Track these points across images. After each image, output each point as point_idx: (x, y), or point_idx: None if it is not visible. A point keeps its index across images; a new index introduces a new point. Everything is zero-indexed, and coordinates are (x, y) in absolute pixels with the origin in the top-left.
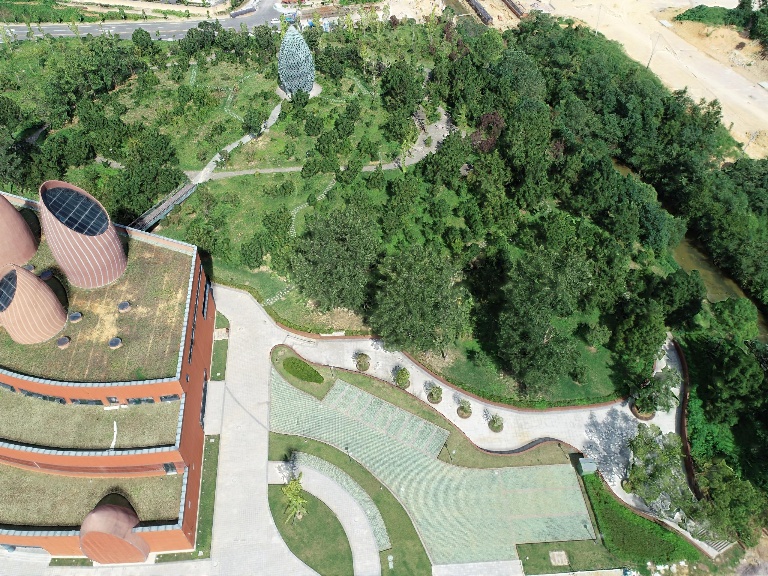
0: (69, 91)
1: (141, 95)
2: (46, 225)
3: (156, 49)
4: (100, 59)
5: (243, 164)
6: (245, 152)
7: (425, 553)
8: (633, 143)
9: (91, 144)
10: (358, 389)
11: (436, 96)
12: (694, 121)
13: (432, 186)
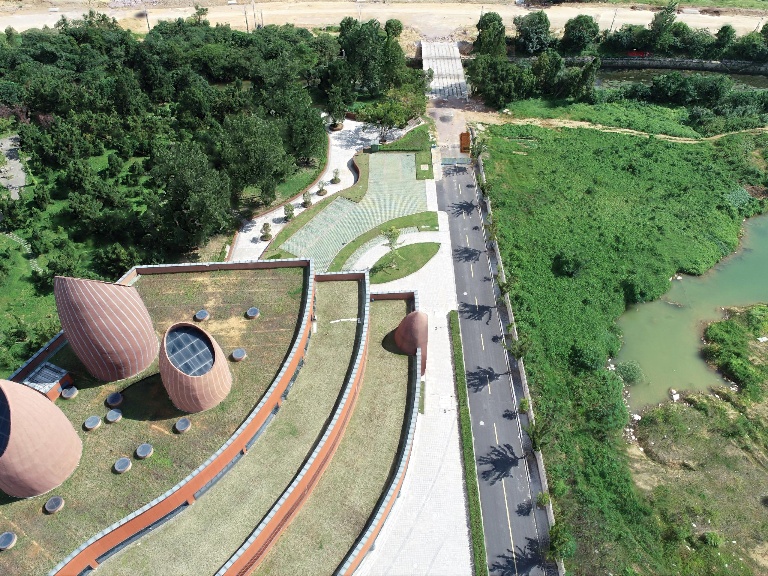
0: None
1: None
2: (113, 305)
3: None
4: None
5: None
6: None
7: (421, 213)
8: (88, 69)
9: None
10: (292, 237)
11: None
12: (100, 30)
13: None
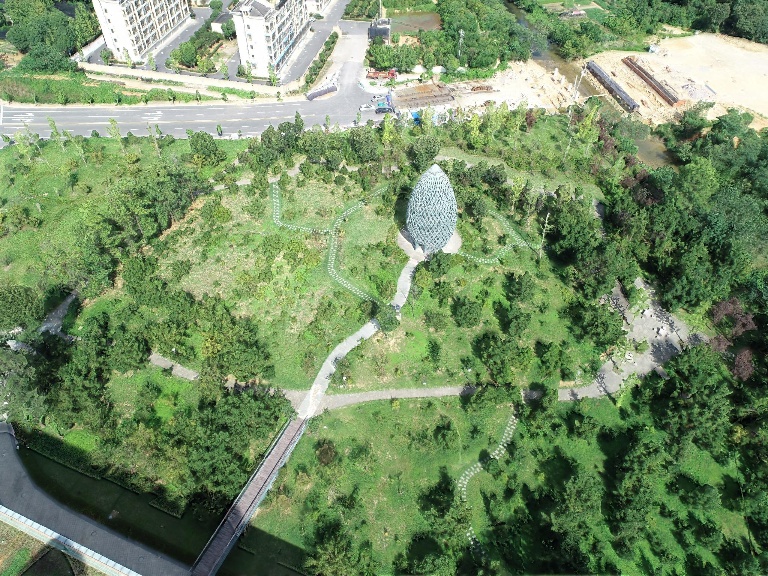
0: (112, 246)
1: (209, 241)
2: None
3: (221, 157)
4: (154, 194)
5: (370, 380)
6: (371, 357)
7: None
8: None
9: (144, 337)
10: None
11: (636, 264)
12: None
13: (677, 446)
